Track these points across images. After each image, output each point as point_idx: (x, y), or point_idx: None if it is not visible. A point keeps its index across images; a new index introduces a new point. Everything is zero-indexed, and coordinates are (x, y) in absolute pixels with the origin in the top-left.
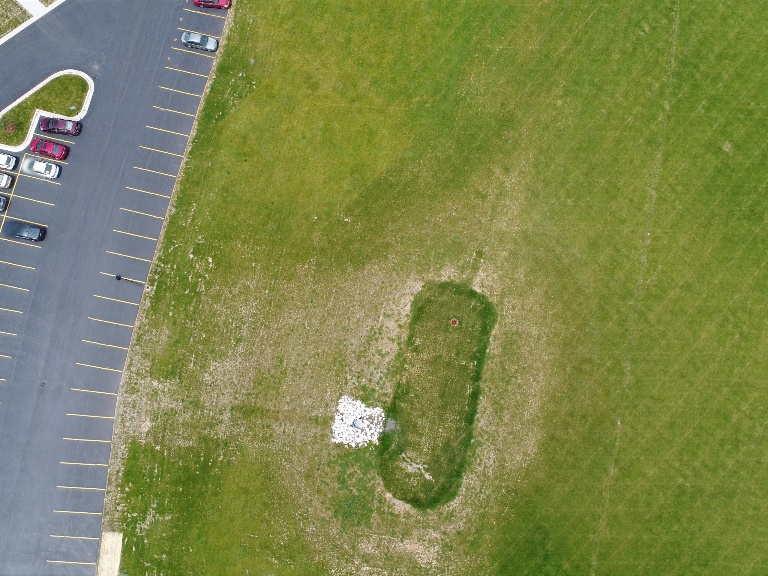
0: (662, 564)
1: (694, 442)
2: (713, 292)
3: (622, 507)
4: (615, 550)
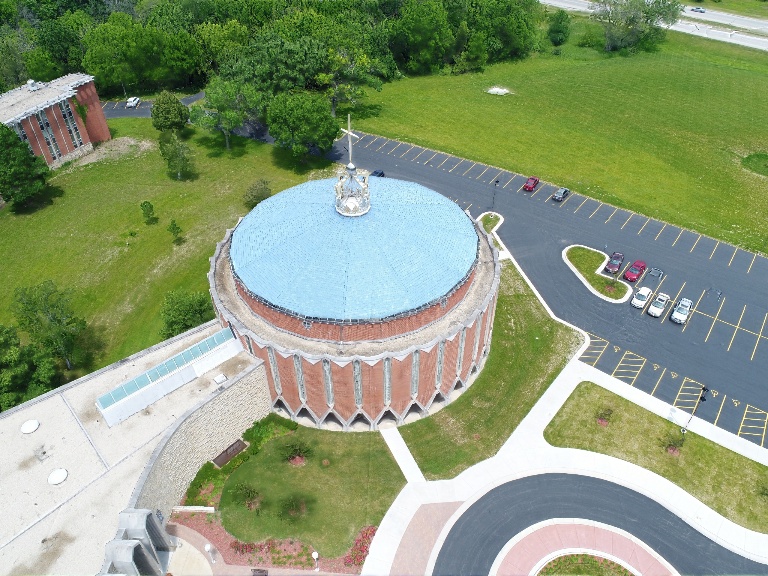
0: None
1: None
2: None
3: None
4: None
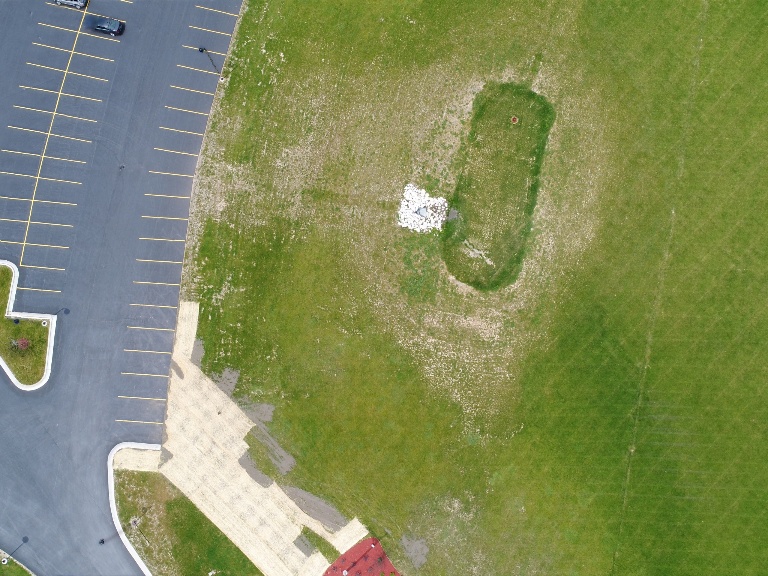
0: (715, 342)
1: (745, 231)
2: (763, 94)
3: (676, 289)
4: (670, 328)
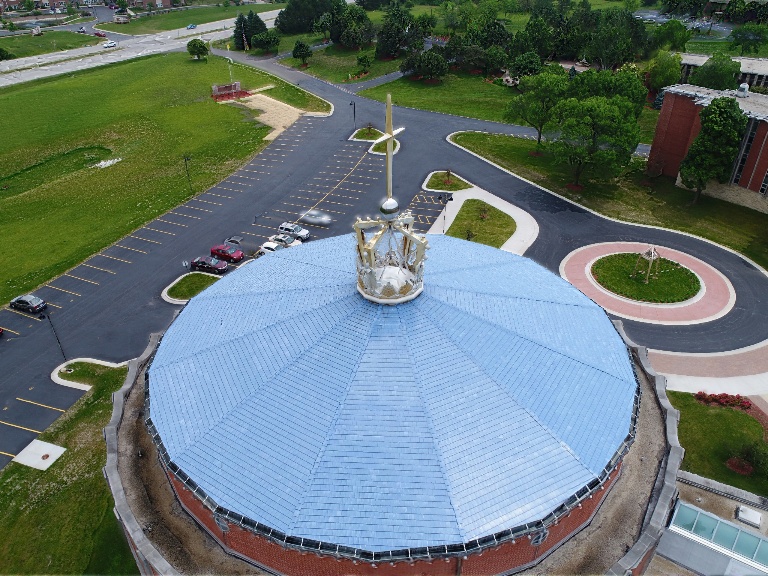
0: None
1: None
2: None
3: None
4: None
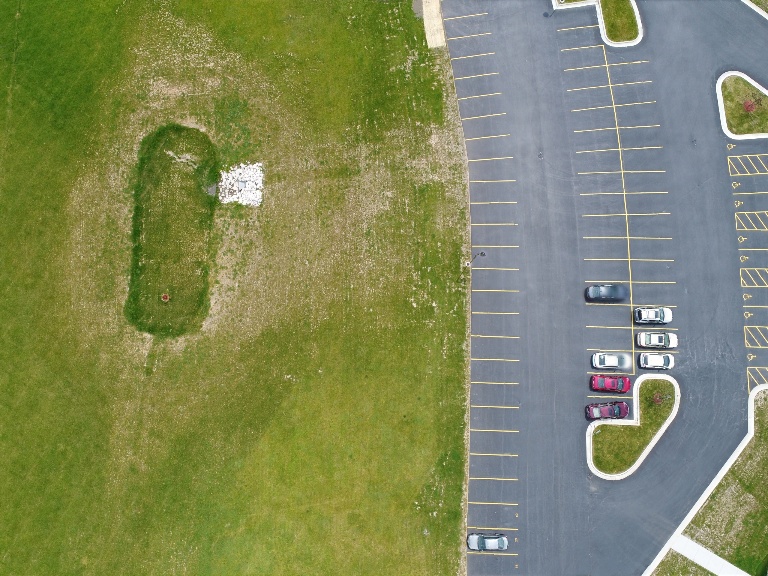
0: None
1: None
2: None
3: None
4: None
